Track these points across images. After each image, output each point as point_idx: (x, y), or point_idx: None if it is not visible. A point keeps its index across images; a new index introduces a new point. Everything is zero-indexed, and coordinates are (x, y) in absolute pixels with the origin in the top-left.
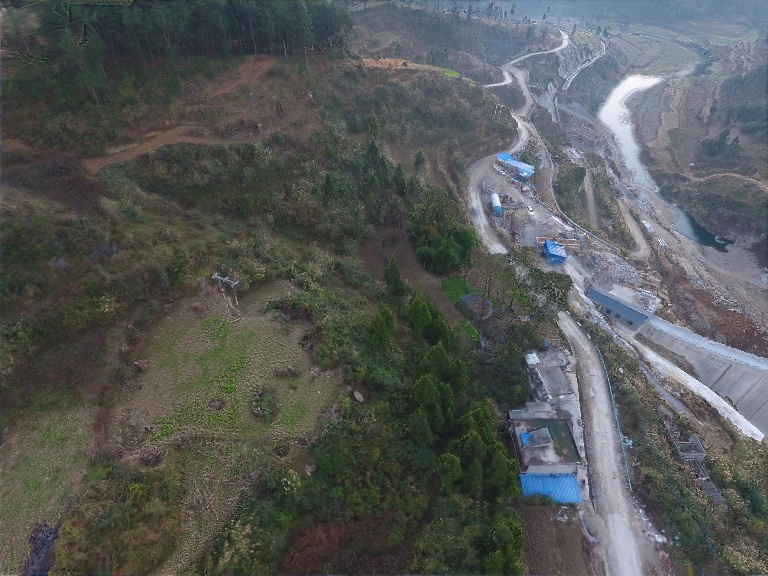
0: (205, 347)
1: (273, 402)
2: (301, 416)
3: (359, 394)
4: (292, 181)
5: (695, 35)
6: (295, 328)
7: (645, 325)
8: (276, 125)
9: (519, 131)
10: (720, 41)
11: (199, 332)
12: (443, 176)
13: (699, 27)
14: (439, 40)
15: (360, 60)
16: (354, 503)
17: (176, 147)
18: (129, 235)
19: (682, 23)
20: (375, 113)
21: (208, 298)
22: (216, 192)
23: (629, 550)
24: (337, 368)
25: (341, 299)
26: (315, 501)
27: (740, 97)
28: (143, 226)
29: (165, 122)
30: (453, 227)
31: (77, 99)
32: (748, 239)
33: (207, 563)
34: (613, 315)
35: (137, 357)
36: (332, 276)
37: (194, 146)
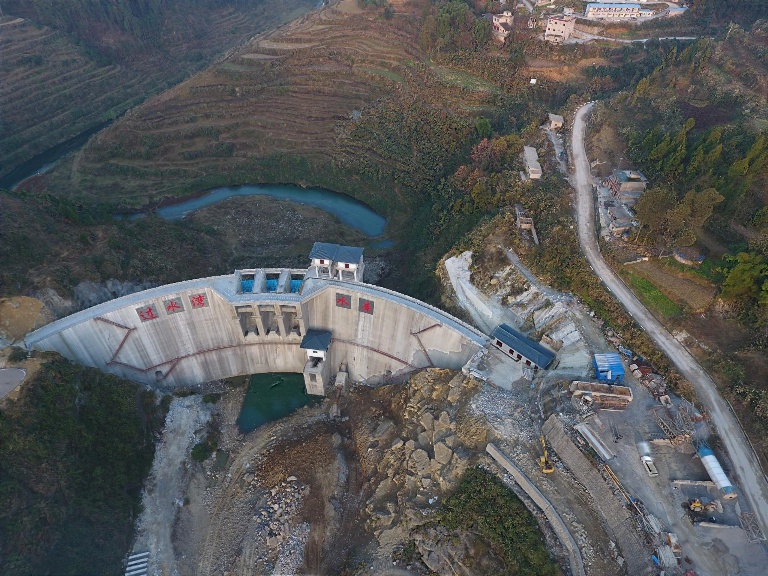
0: None
1: None
2: (761, 123)
3: None
4: None
5: None
6: None
7: None
8: None
9: None
10: None
11: None
12: None
13: None
14: None
15: None
16: None
17: None
18: None
19: None
20: None
21: None
22: None
23: (580, 176)
24: None
25: None
26: None
27: None
28: None
29: None
30: None
31: None
32: None
33: None
34: None
35: None
36: None
37: None
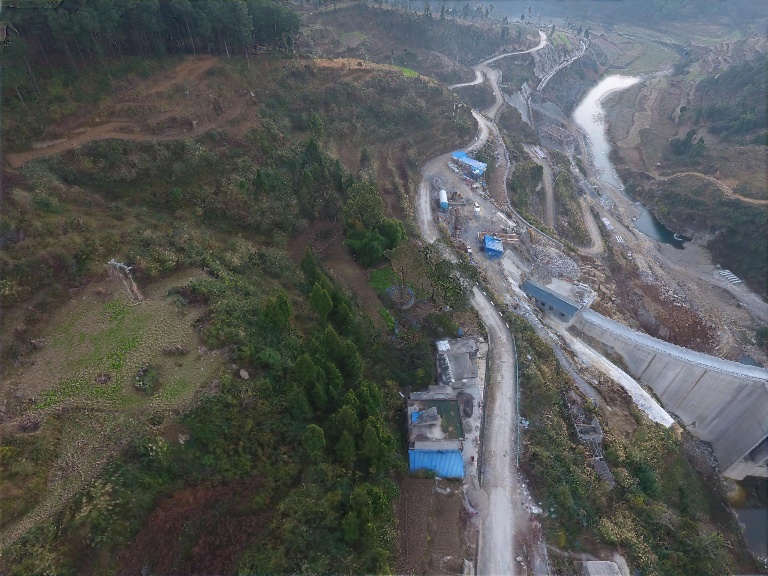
0: (102, 328)
1: (156, 377)
2: (181, 390)
3: (245, 372)
4: (224, 176)
5: (678, 36)
6: (191, 311)
7: (578, 317)
8: (212, 122)
9: (480, 130)
10: (702, 42)
11: (99, 314)
12: (391, 173)
13: (682, 28)
14: (411, 40)
15: (310, 60)
16: (224, 469)
17: (103, 142)
18: (37, 224)
19: (666, 24)
20: (324, 111)
21: (114, 283)
22: (145, 186)
23: (505, 520)
24: (224, 348)
25: (249, 286)
26: (186, 467)
27: (712, 97)
28: (56, 216)
29: (95, 119)
30: (376, 220)
31: (3, 96)
32: (704, 236)
33: (64, 517)
34: (547, 307)
35: (35, 336)
36: (253, 266)
37: (122, 142)
